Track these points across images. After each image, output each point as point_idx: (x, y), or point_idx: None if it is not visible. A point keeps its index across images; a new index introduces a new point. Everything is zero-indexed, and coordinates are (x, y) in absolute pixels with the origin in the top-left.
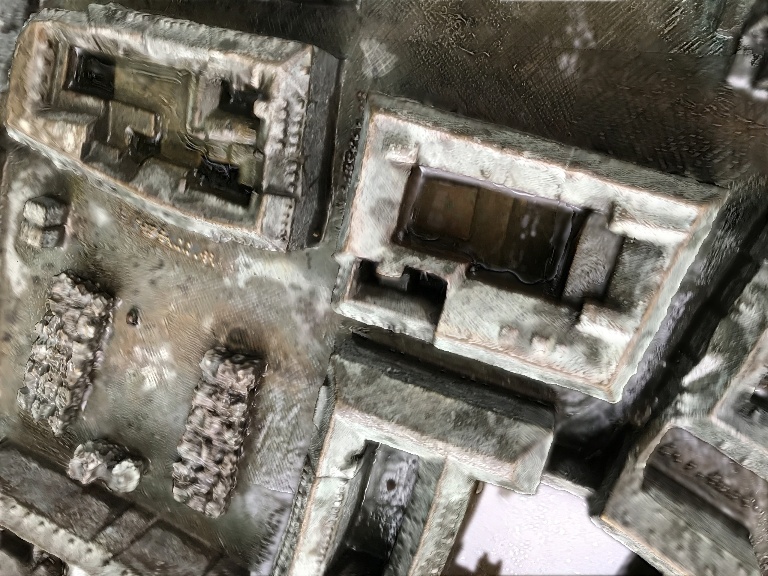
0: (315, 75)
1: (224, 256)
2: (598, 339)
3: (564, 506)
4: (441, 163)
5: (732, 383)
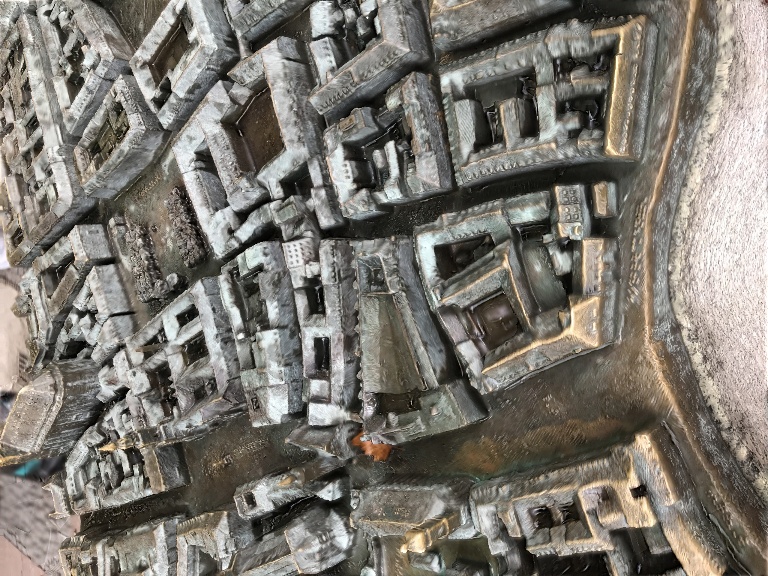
0: (128, 80)
1: (160, 172)
2: (195, 38)
3: None
4: (150, 55)
5: (228, 6)
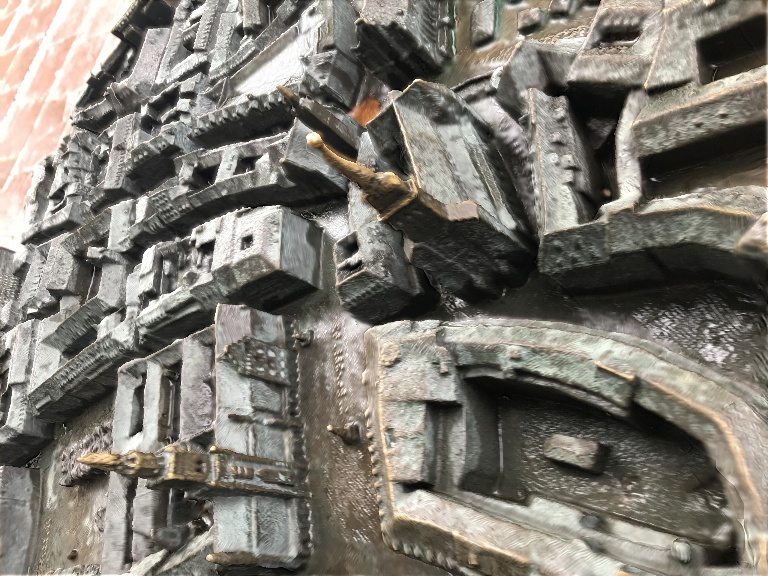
0: None
1: (47, 516)
2: (12, 340)
3: None
4: None
5: None
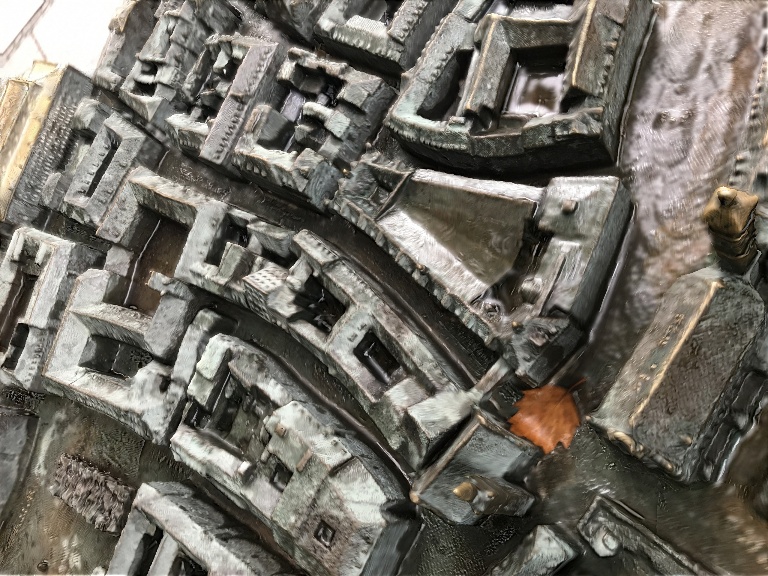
0: None
1: (32, 484)
2: (45, 255)
3: (155, 265)
4: None
5: None
